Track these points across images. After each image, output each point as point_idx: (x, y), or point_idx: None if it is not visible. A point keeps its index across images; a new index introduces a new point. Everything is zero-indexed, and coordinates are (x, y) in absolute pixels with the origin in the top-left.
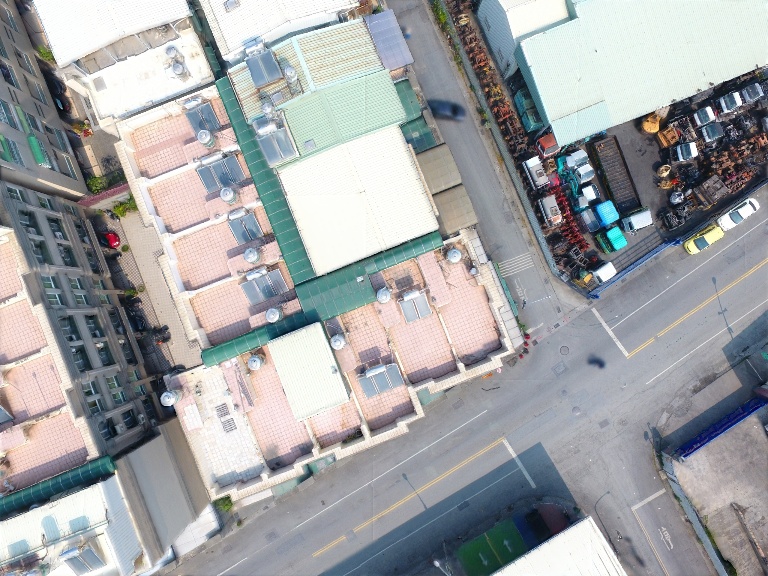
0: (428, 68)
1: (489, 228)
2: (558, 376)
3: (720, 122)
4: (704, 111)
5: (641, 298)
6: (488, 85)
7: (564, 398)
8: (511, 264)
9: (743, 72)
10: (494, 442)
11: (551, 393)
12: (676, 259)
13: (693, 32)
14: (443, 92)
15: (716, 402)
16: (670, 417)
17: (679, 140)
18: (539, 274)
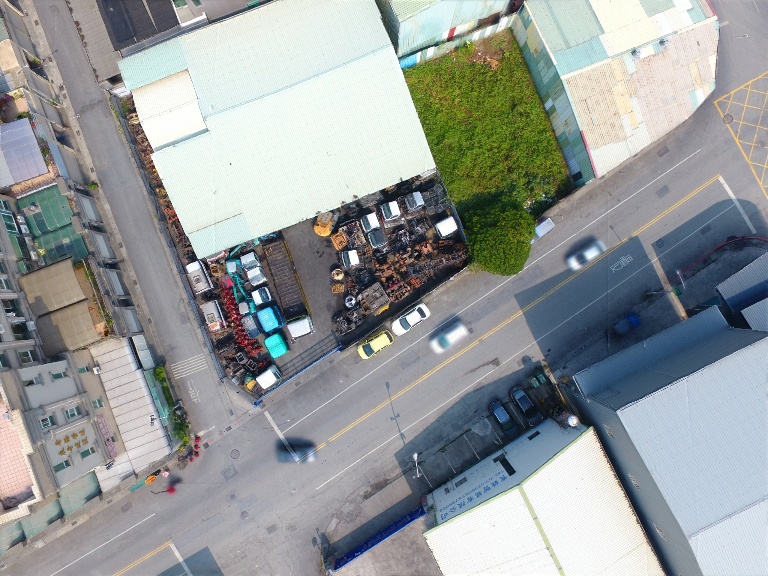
0: (108, 164)
1: (164, 328)
2: (227, 480)
3: (398, 225)
4: (366, 218)
5: (314, 402)
6: (160, 185)
7: (233, 502)
8: (185, 365)
9: (387, 185)
10: (161, 546)
11: (220, 497)
12: (350, 363)
13: (334, 145)
14: (123, 189)
15: (385, 509)
16: (339, 523)
17: (348, 245)
18: (213, 376)
